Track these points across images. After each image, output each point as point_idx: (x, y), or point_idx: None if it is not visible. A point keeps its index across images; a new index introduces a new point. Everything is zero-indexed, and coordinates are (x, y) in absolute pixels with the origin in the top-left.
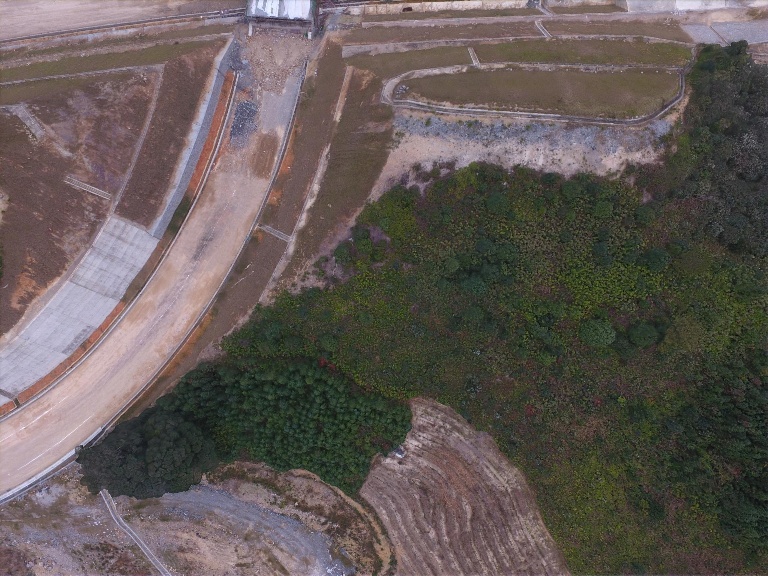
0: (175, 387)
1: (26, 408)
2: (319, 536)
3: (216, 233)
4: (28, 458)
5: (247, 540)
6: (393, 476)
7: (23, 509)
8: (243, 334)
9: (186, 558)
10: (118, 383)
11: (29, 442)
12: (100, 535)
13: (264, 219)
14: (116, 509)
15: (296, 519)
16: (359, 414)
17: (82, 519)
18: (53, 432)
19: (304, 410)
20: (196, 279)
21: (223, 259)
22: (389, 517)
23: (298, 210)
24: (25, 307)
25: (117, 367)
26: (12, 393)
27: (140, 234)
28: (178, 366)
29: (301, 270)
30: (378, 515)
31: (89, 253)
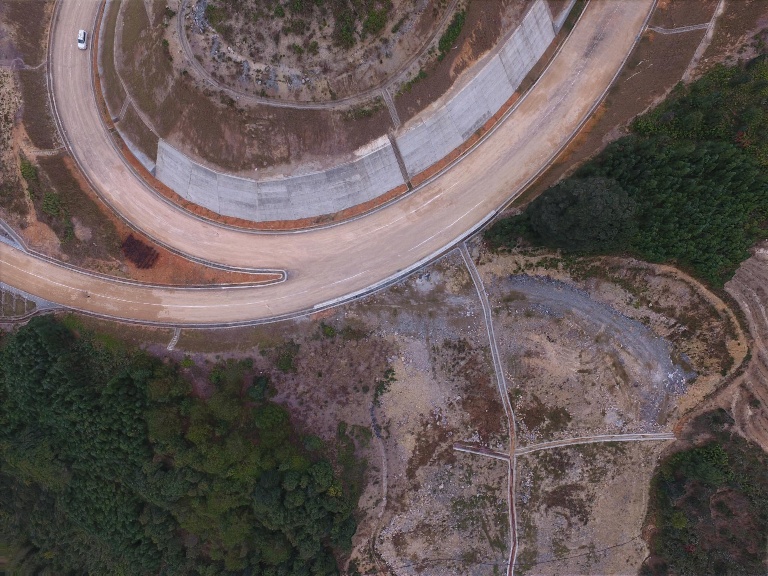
0: (602, 156)
1: (417, 192)
2: (662, 341)
3: (606, 33)
4: (419, 240)
5: (597, 342)
6: (765, 266)
7: (403, 295)
8: (659, 112)
9: (529, 364)
10: (510, 170)
11: (420, 224)
12: (463, 330)
13: (655, 21)
14: (488, 301)
15: (643, 323)
16: (767, 188)
17: (457, 308)
18: (444, 215)
19: (710, 187)
20: (587, 75)
21: (613, 57)
22: (751, 310)
23: (714, 0)
24: (455, 77)
25: (509, 155)
26: (409, 174)
27: (548, 24)
28: (573, 153)
29: (735, 45)
30: (741, 308)
31: (518, 29)
